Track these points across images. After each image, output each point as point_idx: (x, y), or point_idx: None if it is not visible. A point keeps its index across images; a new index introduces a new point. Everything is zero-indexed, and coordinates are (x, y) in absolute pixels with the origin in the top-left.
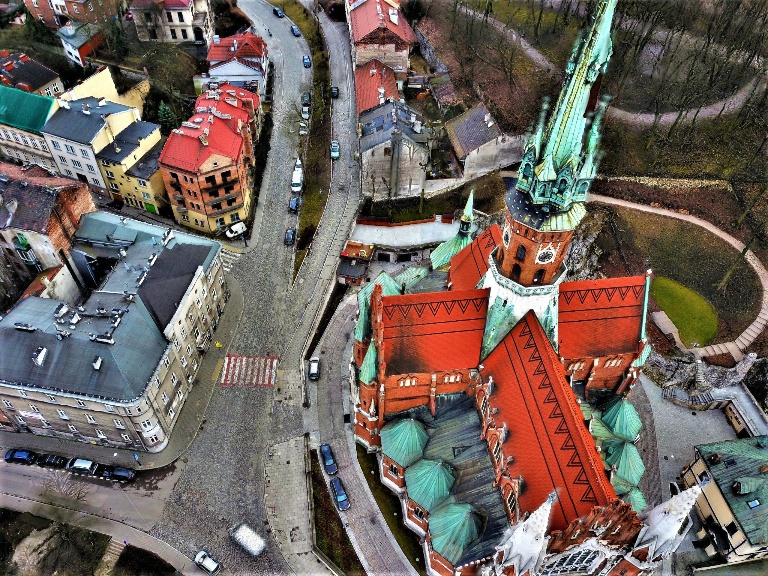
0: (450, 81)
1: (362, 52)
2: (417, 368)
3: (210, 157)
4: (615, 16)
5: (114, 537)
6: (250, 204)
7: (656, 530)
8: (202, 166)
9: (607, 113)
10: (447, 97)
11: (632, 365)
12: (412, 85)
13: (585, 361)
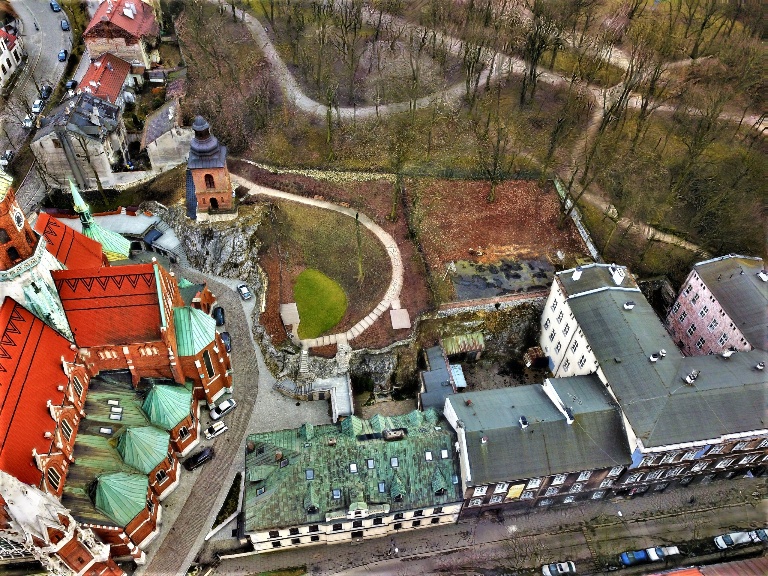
0: (185, 75)
1: (92, 46)
2: None
3: None
4: (342, 11)
5: None
6: None
7: (12, 513)
8: None
9: (304, 107)
10: (174, 91)
11: (170, 354)
12: (154, 79)
13: (113, 349)
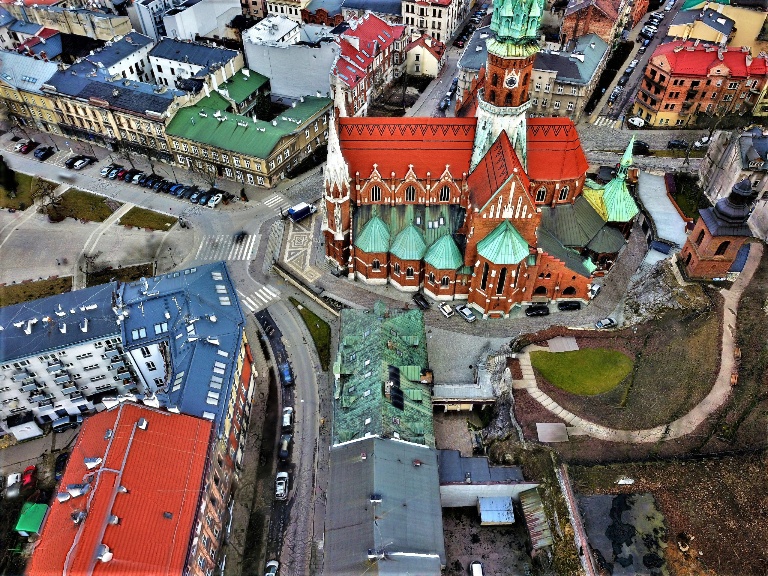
0: None
1: None
2: None
3: (662, 55)
4: None
5: (411, 108)
6: (671, 126)
7: None
8: (655, 58)
9: None
10: None
11: (471, 232)
12: None
13: None
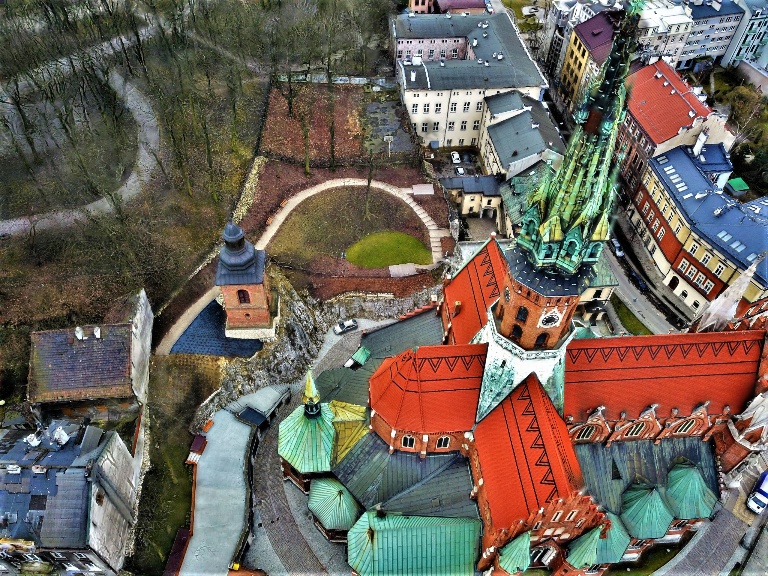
0: None
1: None
2: (584, 488)
3: None
4: None
5: None
6: None
7: None
8: None
9: None
10: None
11: None
12: None
13: None
